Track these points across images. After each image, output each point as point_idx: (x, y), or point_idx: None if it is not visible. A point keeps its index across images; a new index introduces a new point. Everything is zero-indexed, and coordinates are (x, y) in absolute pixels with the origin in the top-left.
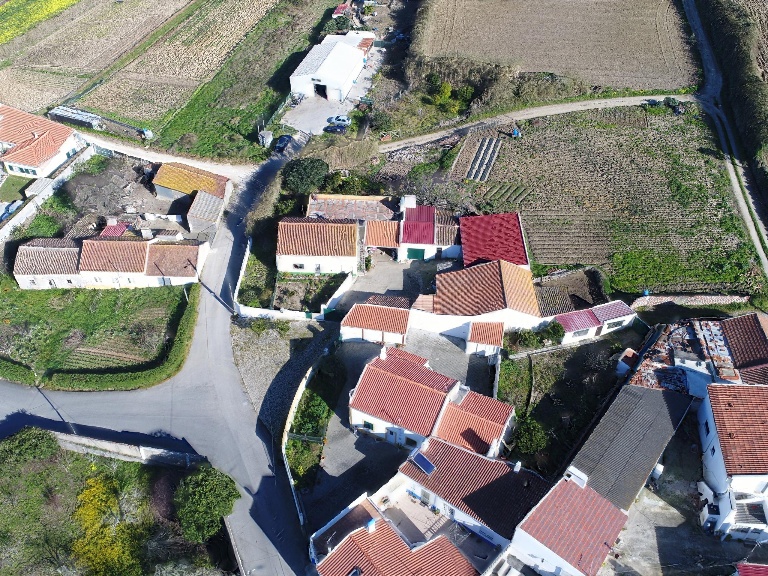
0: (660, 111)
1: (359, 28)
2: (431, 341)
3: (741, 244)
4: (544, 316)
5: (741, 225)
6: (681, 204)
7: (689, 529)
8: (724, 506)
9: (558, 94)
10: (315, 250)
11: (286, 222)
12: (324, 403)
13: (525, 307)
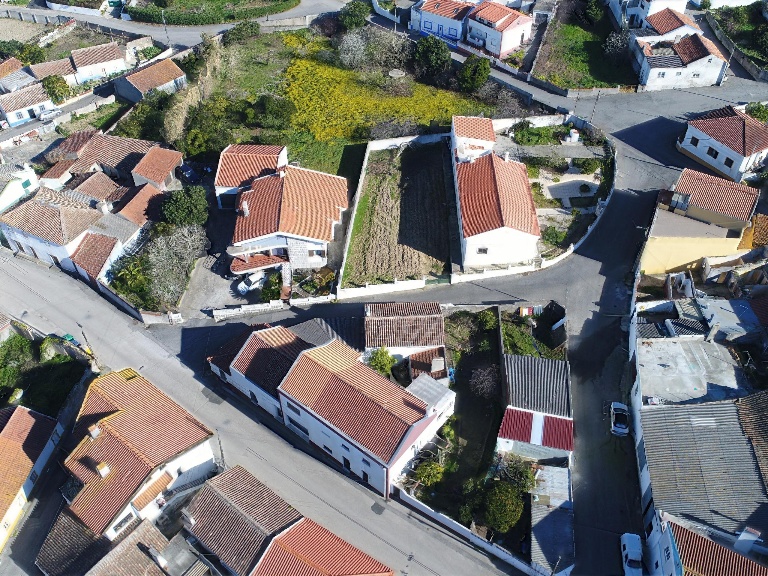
0: None
1: None
2: None
3: None
4: None
5: None
6: None
7: None
8: None
9: None
10: None
11: None
12: None
13: None
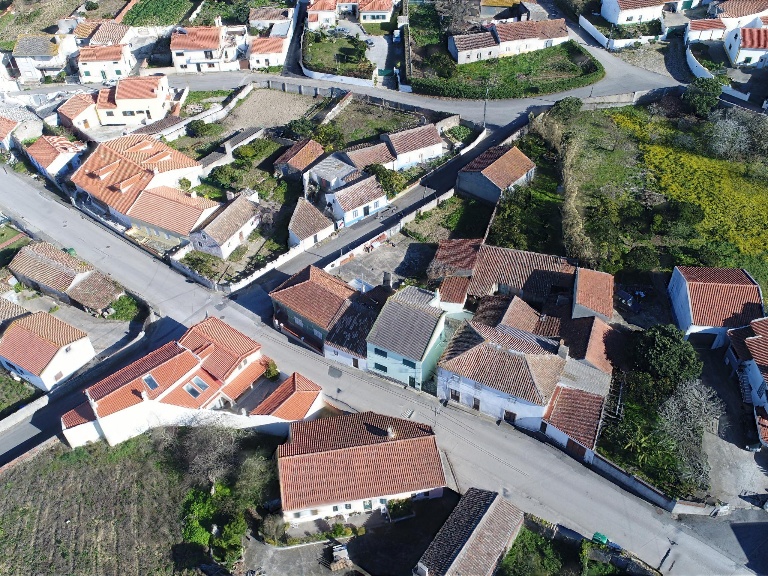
0: None
1: None
2: None
3: None
4: None
5: None
6: None
7: None
8: None
9: None
10: (641, 5)
11: None
12: (710, 62)
13: None
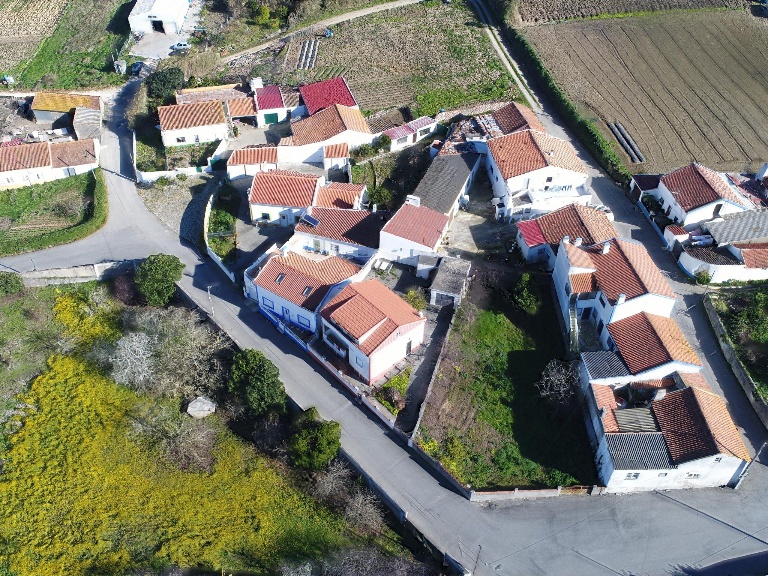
0: (434, 4)
1: None
2: (297, 167)
3: (502, 74)
4: (375, 133)
5: (501, 64)
6: (459, 59)
7: (490, 223)
8: (506, 199)
9: (355, 3)
10: (192, 123)
11: (163, 106)
12: (229, 214)
13: (360, 129)
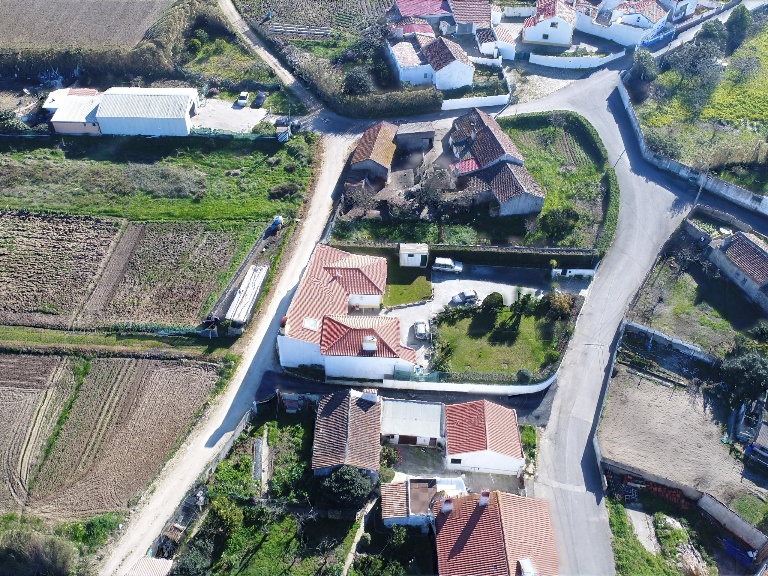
0: None
1: (45, 97)
2: None
3: None
4: None
5: None
6: None
7: None
8: None
9: None
10: None
11: (455, 57)
12: None
13: None
